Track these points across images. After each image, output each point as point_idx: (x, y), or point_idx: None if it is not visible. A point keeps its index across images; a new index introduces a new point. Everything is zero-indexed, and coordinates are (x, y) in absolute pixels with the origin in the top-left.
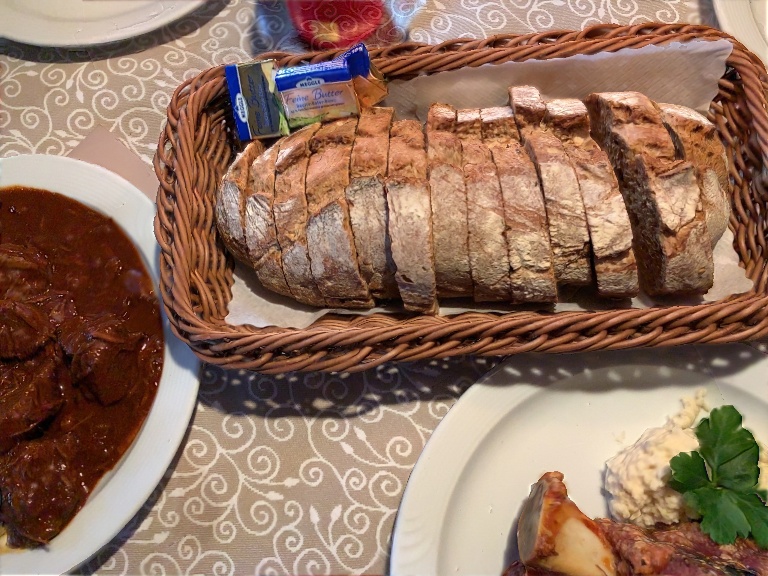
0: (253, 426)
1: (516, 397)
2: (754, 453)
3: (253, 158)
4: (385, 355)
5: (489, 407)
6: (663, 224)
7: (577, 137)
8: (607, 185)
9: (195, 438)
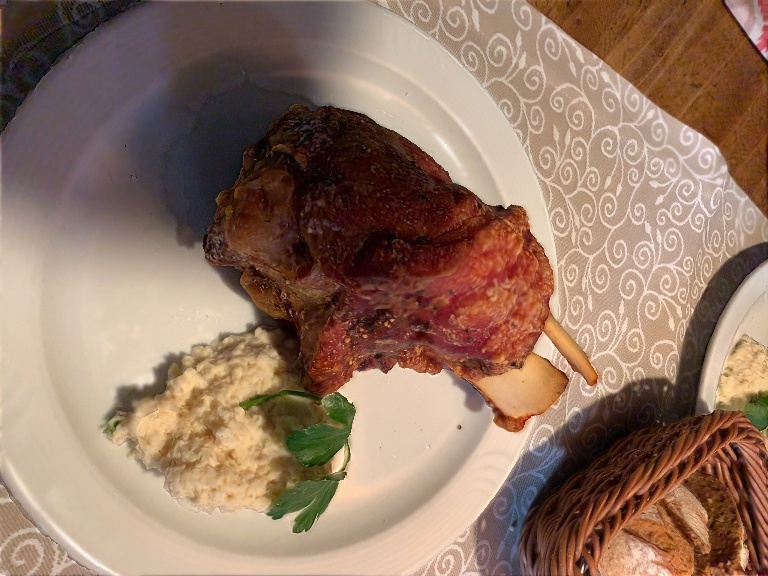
0: None
1: None
2: (765, 403)
3: None
4: None
5: None
6: None
7: None
8: None
9: None
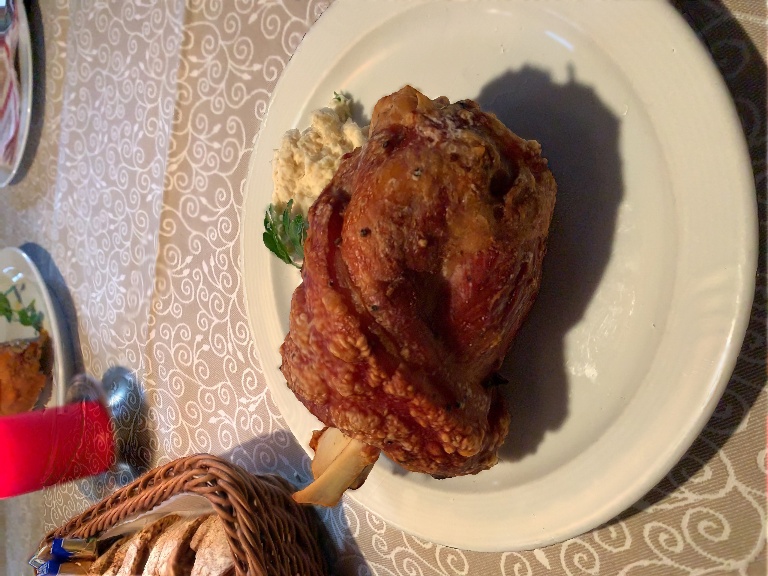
0: None
1: None
2: None
3: None
4: None
5: None
6: None
7: None
8: None
9: None
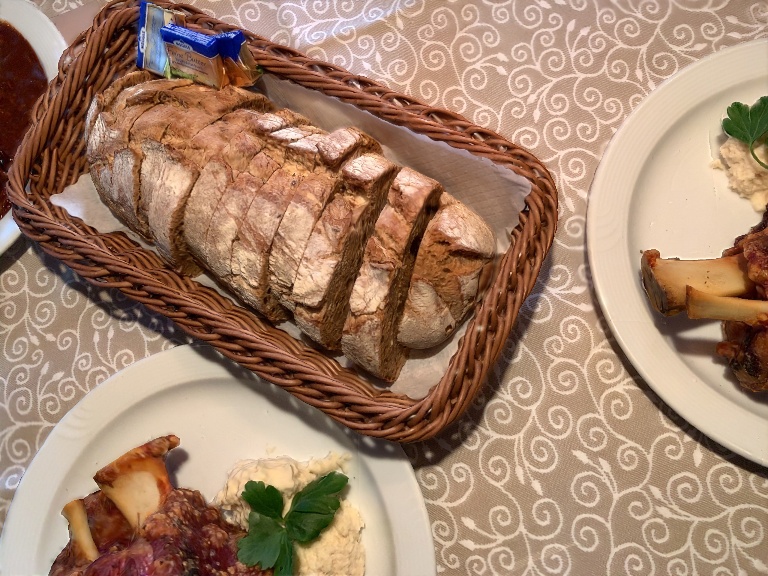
0: (55, 284)
1: (211, 372)
2: (324, 519)
3: (133, 84)
4: (110, 282)
5: (187, 367)
6: (349, 303)
7: (361, 197)
8: (330, 247)
9: (14, 270)
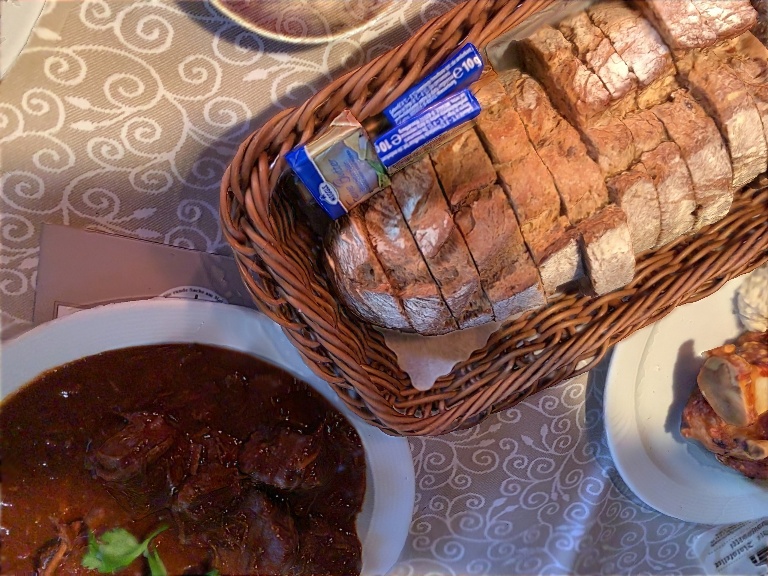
0: None
1: None
2: None
3: None
4: (598, 358)
5: None
6: None
7: None
8: None
9: None
